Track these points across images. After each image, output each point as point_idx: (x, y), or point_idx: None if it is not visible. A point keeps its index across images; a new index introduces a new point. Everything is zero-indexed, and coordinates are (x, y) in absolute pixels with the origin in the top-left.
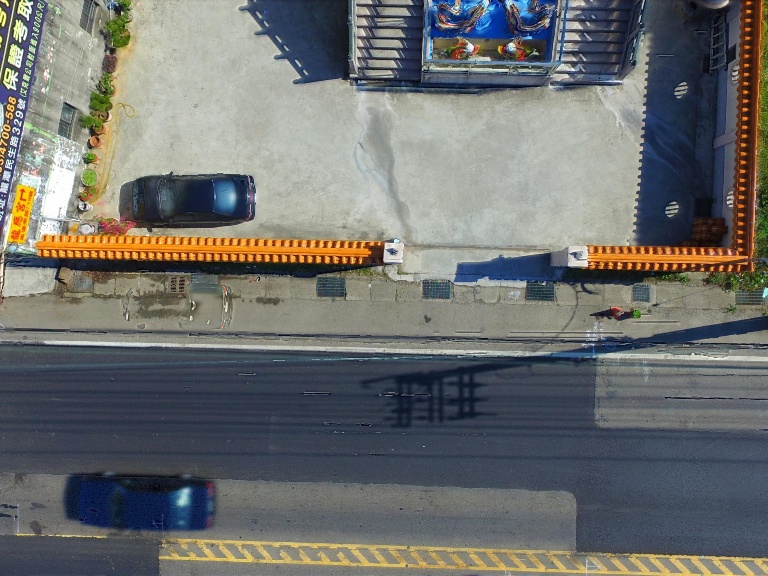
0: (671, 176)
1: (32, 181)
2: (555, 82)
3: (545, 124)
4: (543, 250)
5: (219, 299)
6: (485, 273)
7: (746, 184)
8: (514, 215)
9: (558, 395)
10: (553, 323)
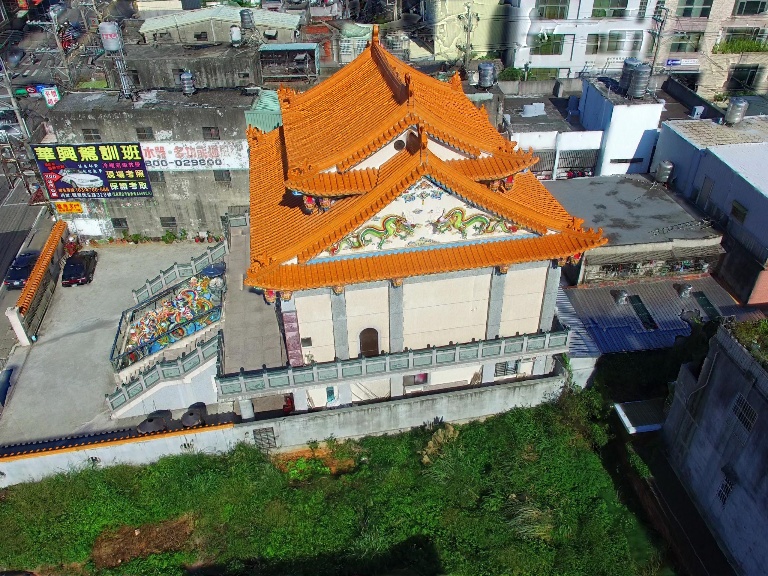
0: None
1: (85, 210)
2: None
3: (93, 389)
4: (7, 403)
5: (20, 278)
6: (2, 382)
7: None
8: (36, 385)
9: None
10: None
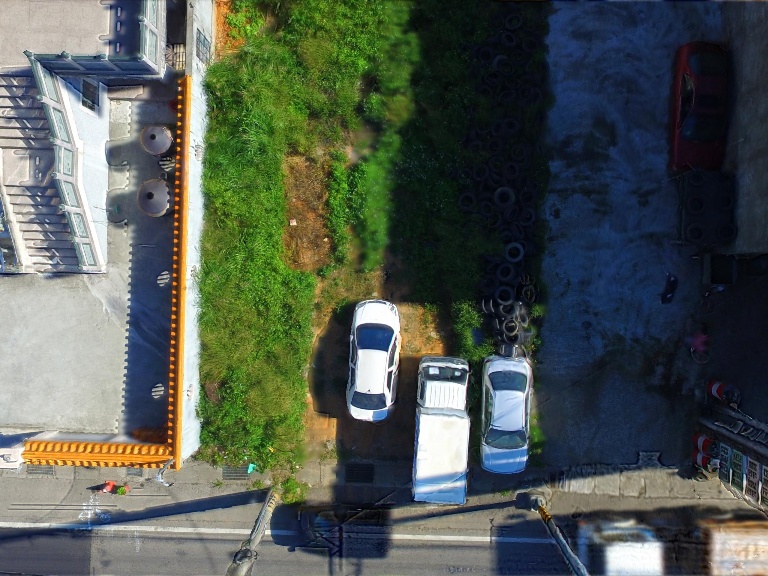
0: (156, 360)
1: None
2: (42, 271)
3: (36, 309)
4: (38, 428)
5: None
6: None
7: (174, 388)
8: (9, 395)
9: (56, 564)
10: (52, 496)
